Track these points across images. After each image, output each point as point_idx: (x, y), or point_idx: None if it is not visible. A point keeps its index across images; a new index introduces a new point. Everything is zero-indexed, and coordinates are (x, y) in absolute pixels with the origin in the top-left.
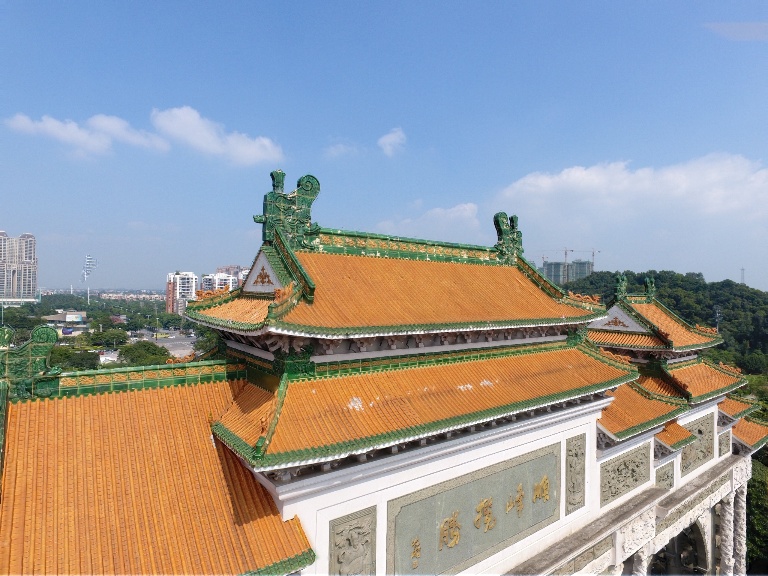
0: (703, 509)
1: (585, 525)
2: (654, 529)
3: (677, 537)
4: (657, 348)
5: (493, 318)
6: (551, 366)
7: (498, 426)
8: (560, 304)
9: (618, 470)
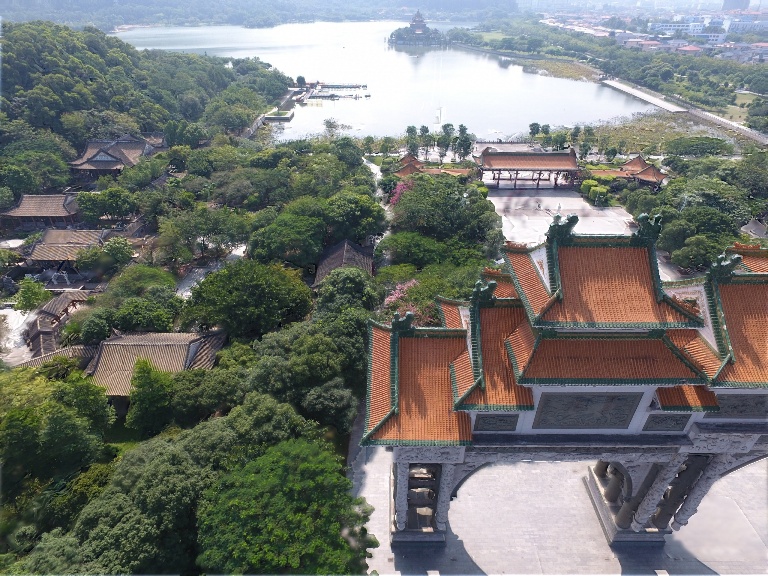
0: None
1: None
2: None
3: None
4: None
5: None
6: None
7: None
8: None
9: None
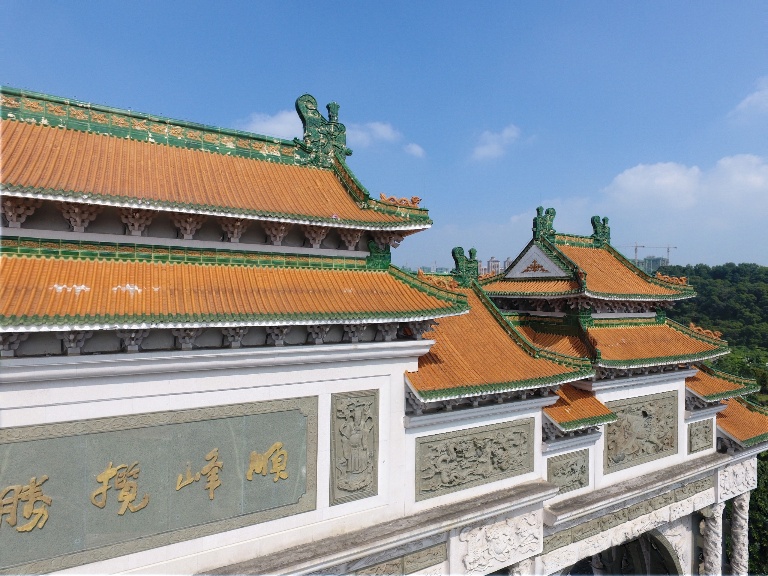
0: (654, 522)
1: (377, 523)
2: (540, 541)
3: (650, 560)
4: (568, 293)
5: (169, 199)
6: (308, 285)
7: (135, 352)
8: (363, 210)
9: (455, 450)
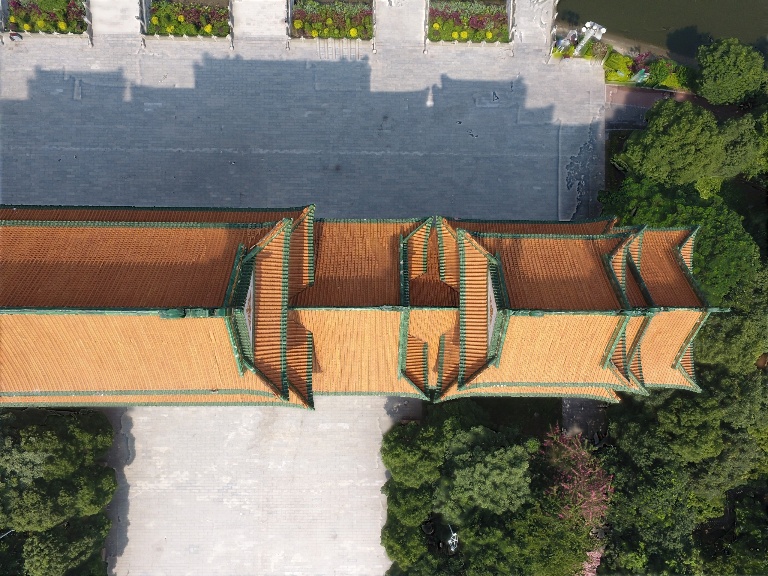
0: None
1: None
2: None
3: None
4: (459, 372)
5: (110, 387)
6: None
7: None
8: None
9: None
